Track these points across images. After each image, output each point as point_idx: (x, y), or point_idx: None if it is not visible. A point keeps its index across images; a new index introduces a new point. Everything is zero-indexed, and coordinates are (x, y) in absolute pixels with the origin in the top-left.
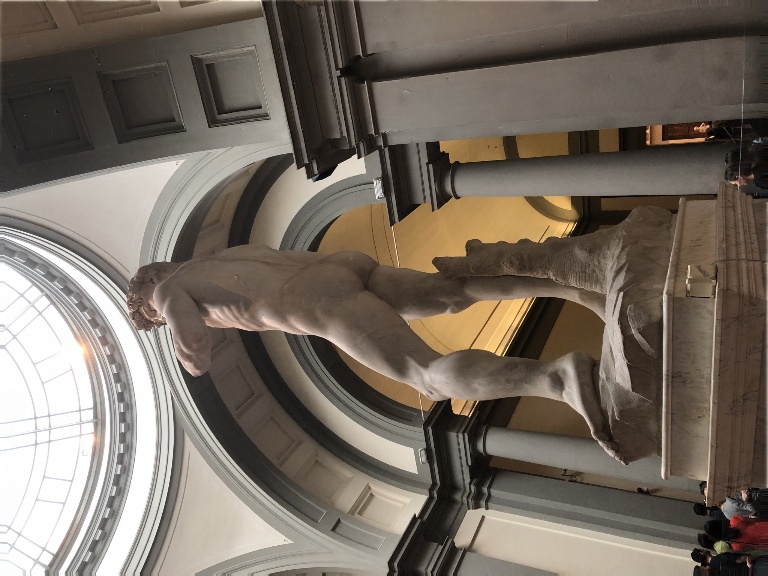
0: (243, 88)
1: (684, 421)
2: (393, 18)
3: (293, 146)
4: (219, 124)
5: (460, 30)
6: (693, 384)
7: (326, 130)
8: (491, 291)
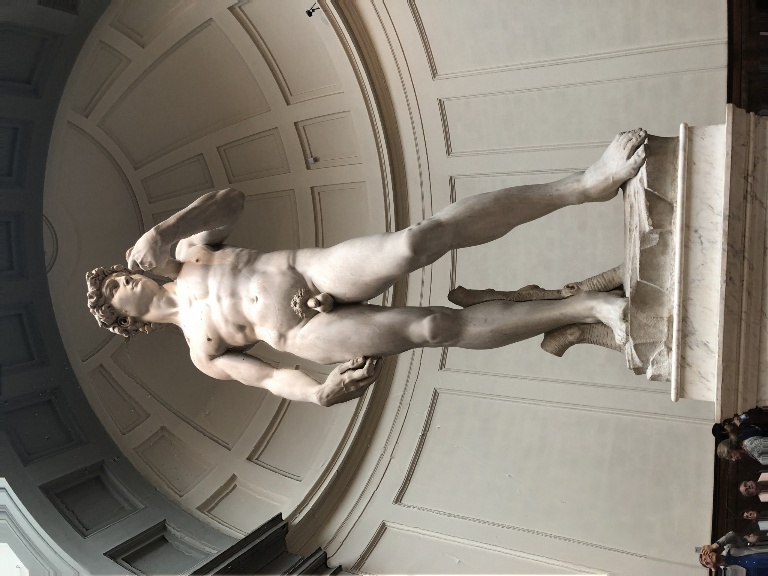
0: (166, 567)
1: None
2: None
3: None
4: None
5: None
6: None
7: None
8: (491, 303)
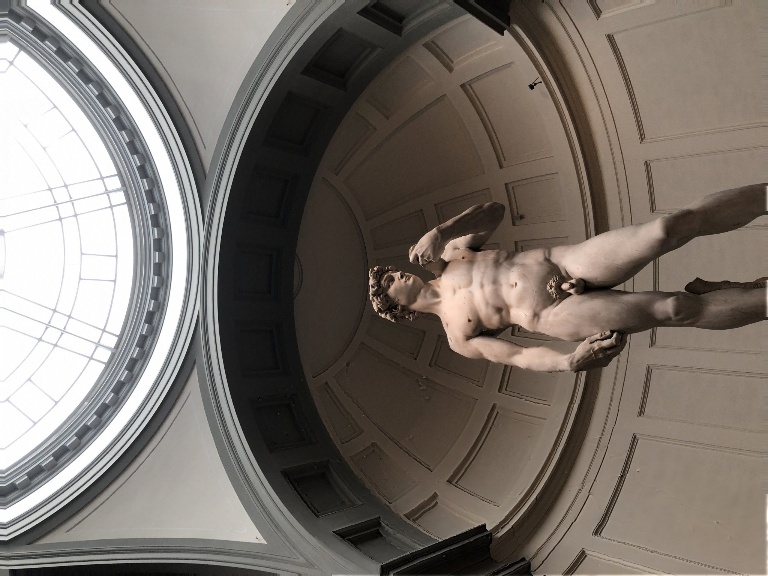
0: None
1: None
2: None
3: (398, 558)
4: (342, 538)
5: None
6: None
7: None
8: None
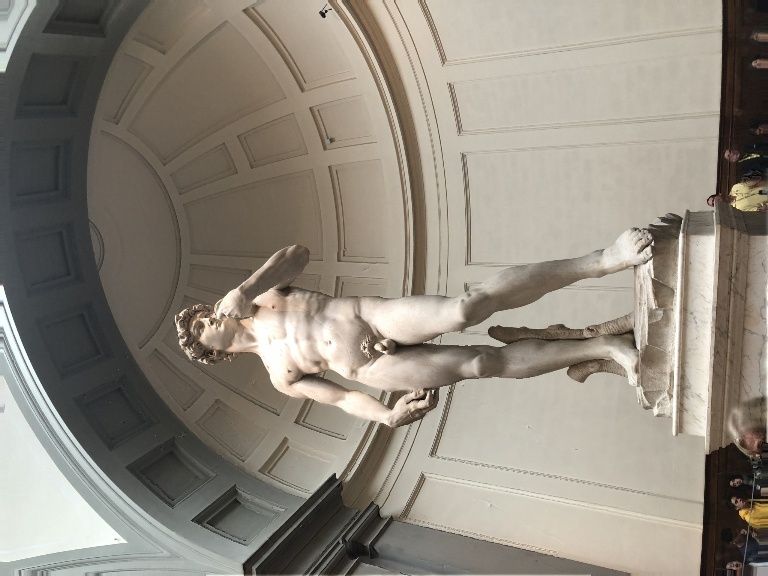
0: (244, 526)
1: (696, 226)
2: (412, 538)
3: (258, 549)
4: None
5: (463, 563)
6: (702, 221)
7: (289, 571)
8: None
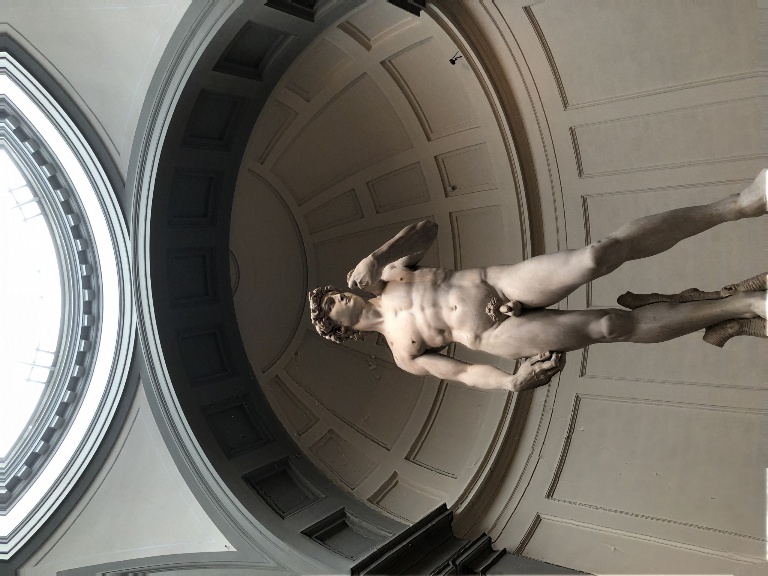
0: (351, 546)
1: None
2: None
3: (367, 557)
4: None
5: None
6: None
7: None
8: None
